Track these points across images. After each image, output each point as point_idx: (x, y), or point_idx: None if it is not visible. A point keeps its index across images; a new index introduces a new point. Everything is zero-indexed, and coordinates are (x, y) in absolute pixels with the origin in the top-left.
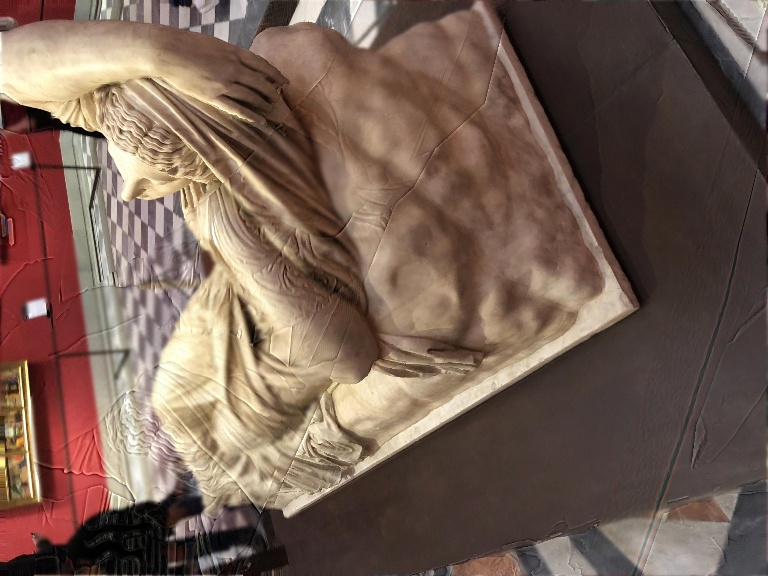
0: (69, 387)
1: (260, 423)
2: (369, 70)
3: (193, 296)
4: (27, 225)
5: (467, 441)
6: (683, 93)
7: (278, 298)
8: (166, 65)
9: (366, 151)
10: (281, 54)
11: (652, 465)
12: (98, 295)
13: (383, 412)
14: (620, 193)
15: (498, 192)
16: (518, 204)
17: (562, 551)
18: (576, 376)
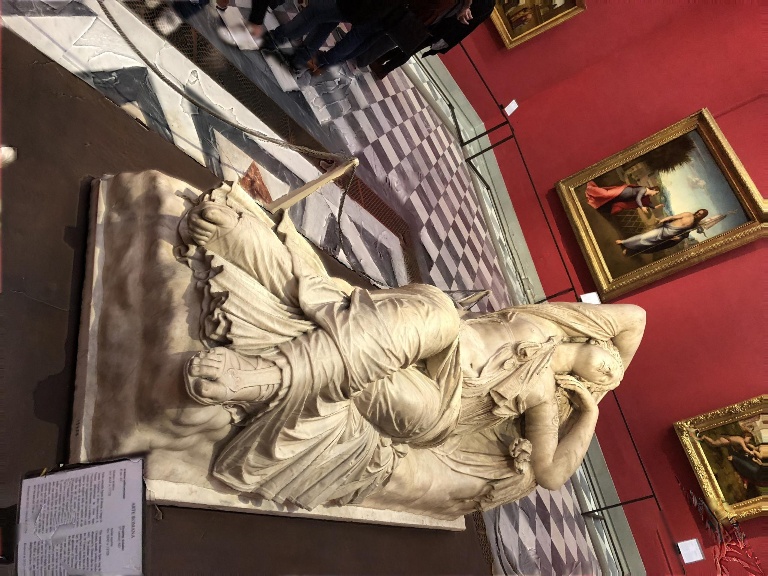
0: None
1: None
2: None
3: None
4: None
5: (380, 545)
6: None
7: None
8: None
9: None
10: None
11: None
12: None
13: (411, 488)
14: None
15: None
16: None
17: None
18: (432, 544)
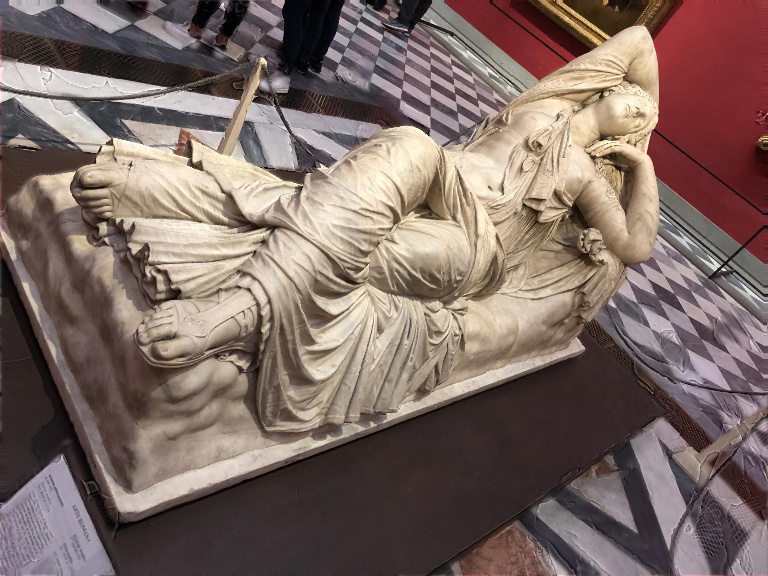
0: None
1: None
2: None
3: None
4: None
5: (501, 408)
6: None
7: None
8: None
9: None
10: None
11: None
12: None
13: (497, 339)
14: None
15: None
16: None
17: (555, 513)
18: (558, 380)
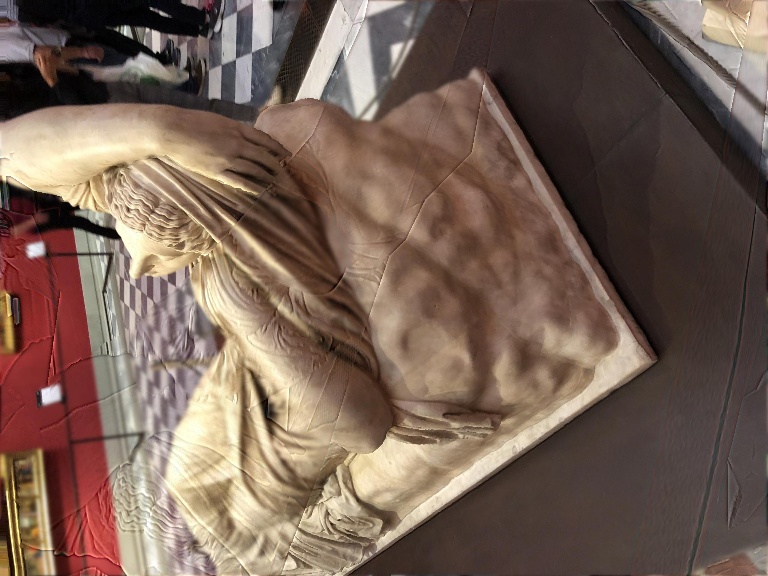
0: (60, 462)
1: (260, 493)
2: (355, 127)
3: (187, 362)
4: (32, 304)
5: (491, 510)
6: (681, 144)
7: (274, 359)
8: (171, 144)
9: (356, 206)
10: (284, 129)
11: (679, 521)
12: (91, 365)
13: (402, 483)
14: (627, 246)
15: (504, 251)
16: (525, 262)
17: None
18: (599, 435)
